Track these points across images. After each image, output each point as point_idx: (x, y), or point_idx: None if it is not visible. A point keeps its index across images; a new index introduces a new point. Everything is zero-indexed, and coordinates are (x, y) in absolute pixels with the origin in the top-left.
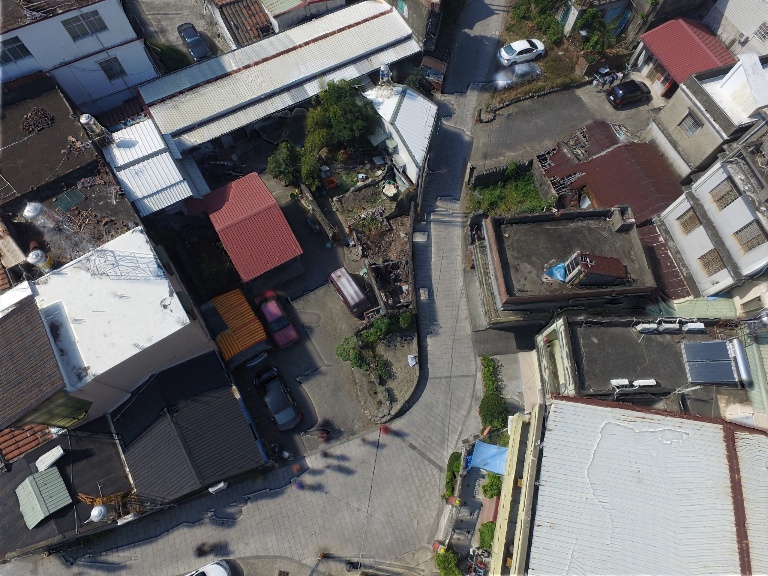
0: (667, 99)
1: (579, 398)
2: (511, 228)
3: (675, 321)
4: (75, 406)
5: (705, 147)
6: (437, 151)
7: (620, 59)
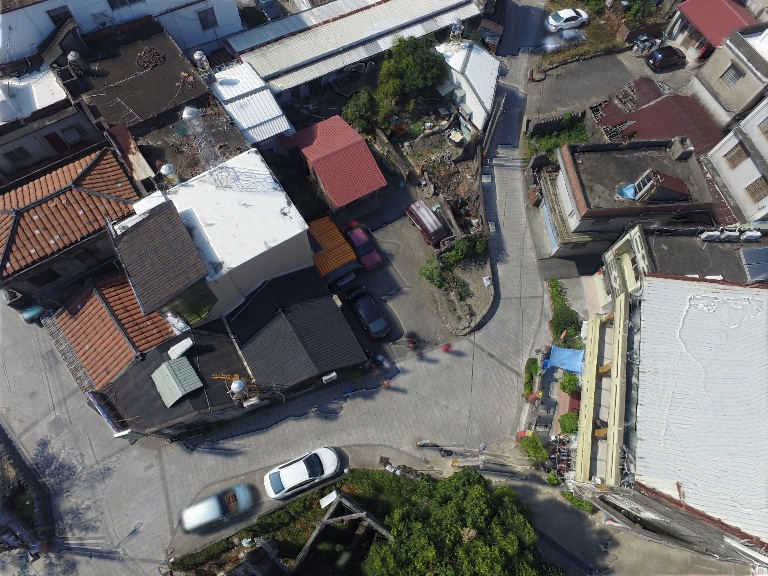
0: (706, 58)
1: (668, 275)
2: (583, 156)
3: (735, 230)
4: (205, 301)
5: (748, 93)
6: (495, 105)
7: (657, 27)
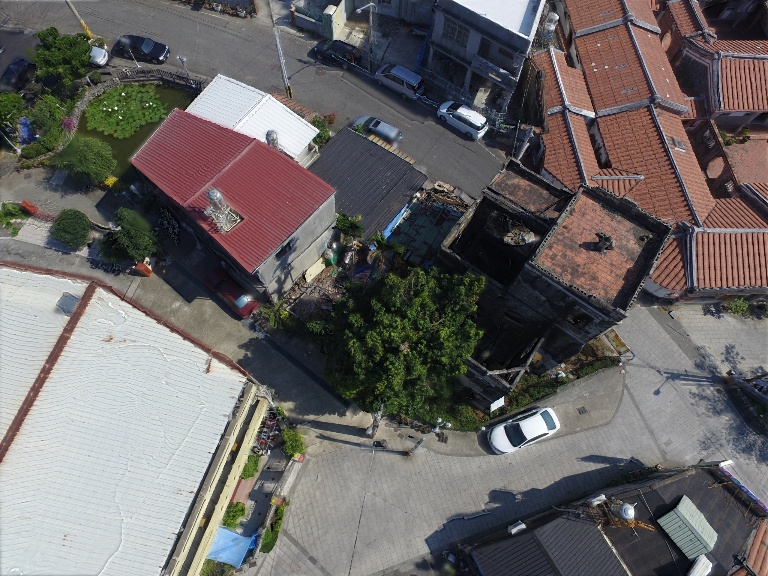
0: None
1: None
2: None
3: None
4: None
5: None
6: None
7: None
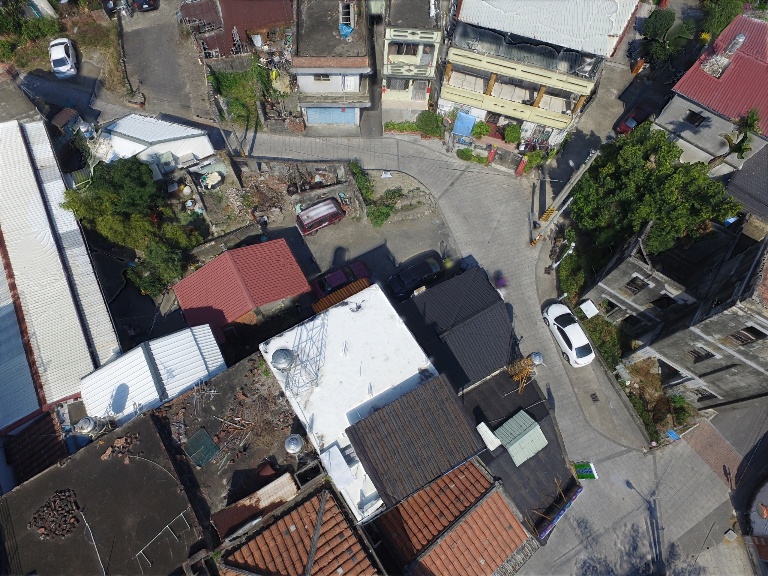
0: None
1: (458, 5)
2: (301, 53)
3: None
4: None
5: None
6: None
7: None
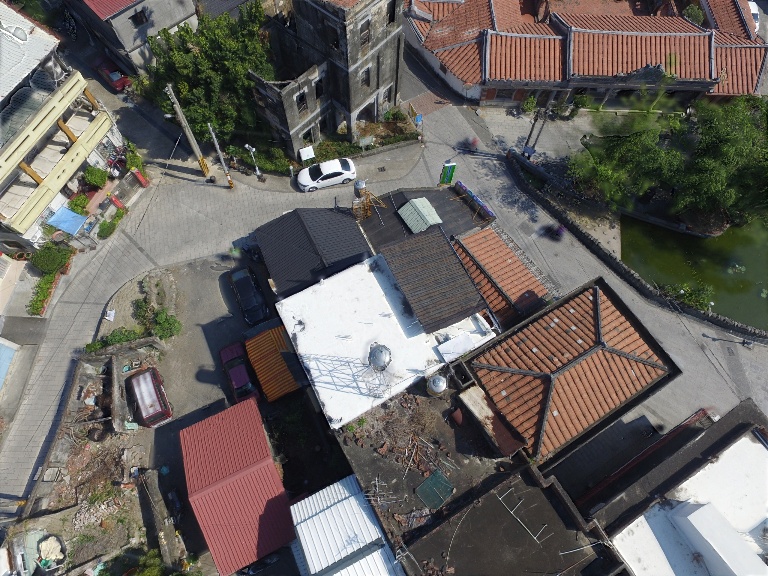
0: None
1: None
2: None
3: None
4: None
5: None
6: None
7: None
